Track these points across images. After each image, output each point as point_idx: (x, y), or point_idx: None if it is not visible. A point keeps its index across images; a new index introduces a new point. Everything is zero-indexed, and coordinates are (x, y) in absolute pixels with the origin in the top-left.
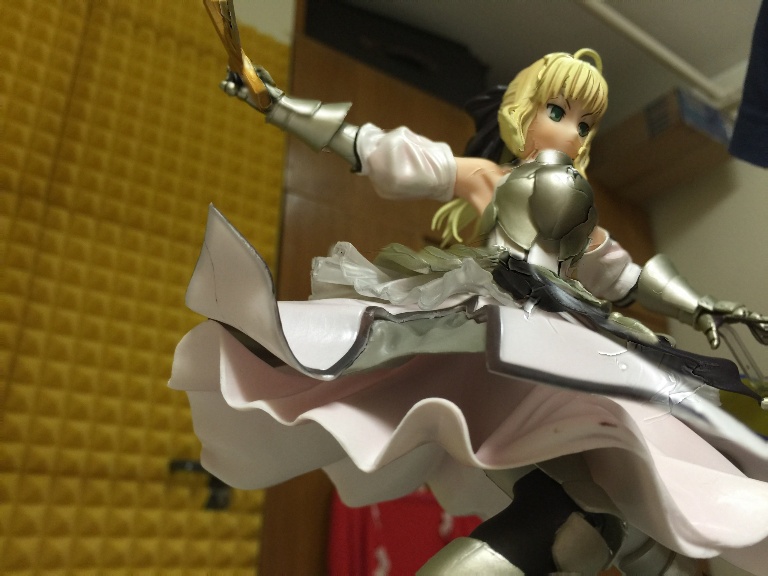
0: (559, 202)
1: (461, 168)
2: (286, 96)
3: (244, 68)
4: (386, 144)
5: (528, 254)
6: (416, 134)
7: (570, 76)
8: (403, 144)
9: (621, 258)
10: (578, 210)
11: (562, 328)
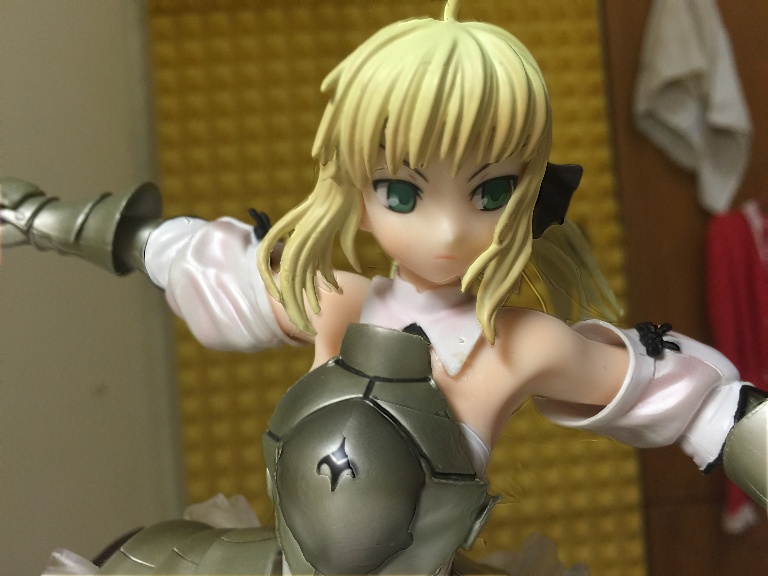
0: (314, 541)
1: (281, 312)
2: None
3: None
4: (169, 280)
5: None
6: (226, 232)
7: (389, 116)
8: (187, 280)
9: (679, 404)
10: (368, 546)
11: None
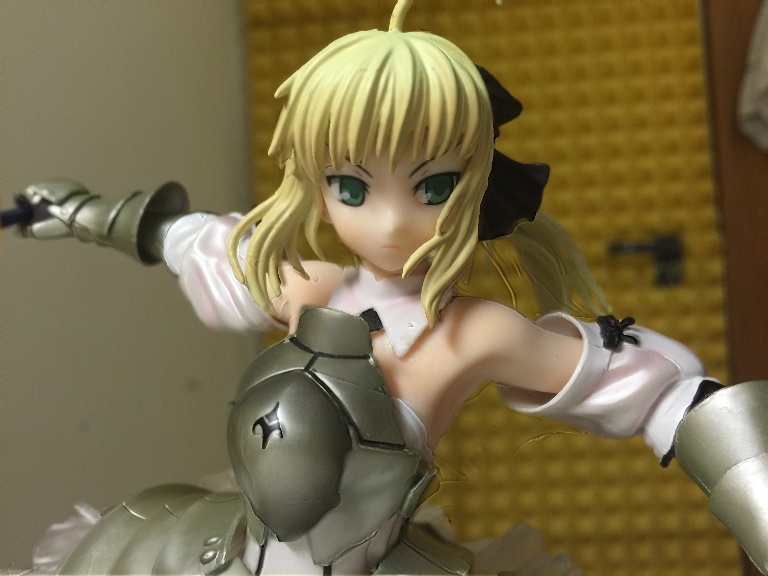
0: (253, 494)
1: None
2: None
3: None
4: None
5: (264, 554)
6: (229, 226)
7: (330, 117)
8: (193, 268)
9: (632, 396)
10: (298, 502)
11: None
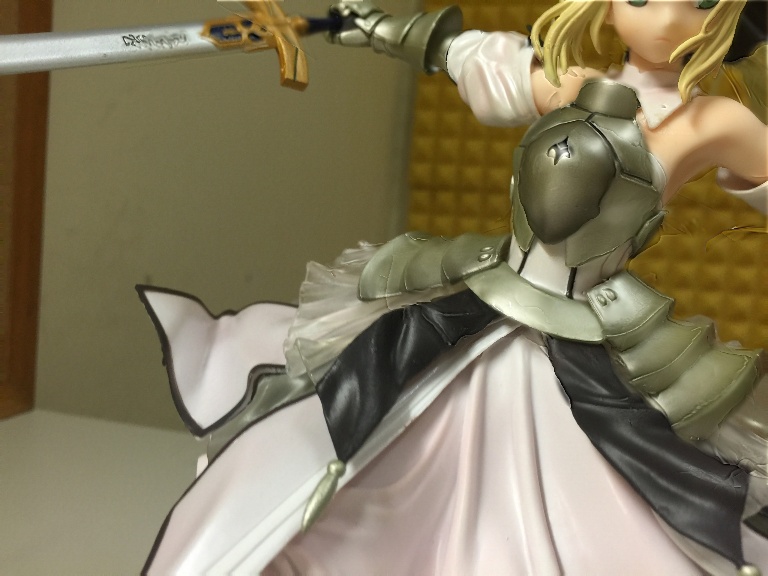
0: (537, 201)
1: (538, 92)
2: None
3: (279, 55)
4: None
5: (526, 259)
6: (508, 37)
7: None
8: (475, 68)
9: None
10: (570, 208)
11: (541, 367)
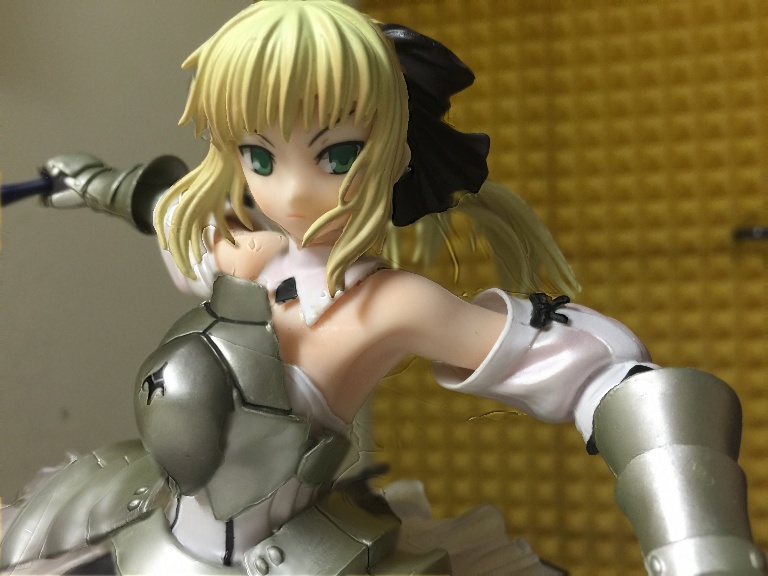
0: None
1: (223, 266)
2: (106, 171)
3: None
4: None
5: (179, 506)
6: None
7: (226, 88)
8: None
9: (555, 376)
10: (183, 457)
11: None
